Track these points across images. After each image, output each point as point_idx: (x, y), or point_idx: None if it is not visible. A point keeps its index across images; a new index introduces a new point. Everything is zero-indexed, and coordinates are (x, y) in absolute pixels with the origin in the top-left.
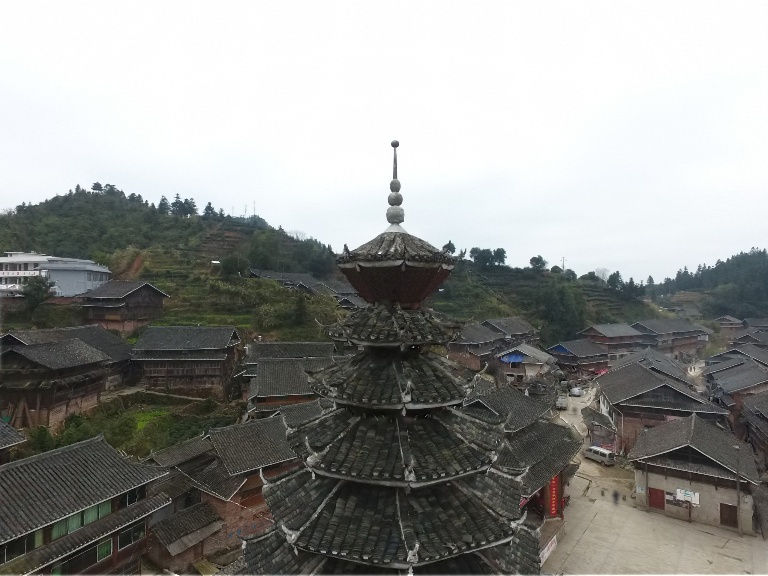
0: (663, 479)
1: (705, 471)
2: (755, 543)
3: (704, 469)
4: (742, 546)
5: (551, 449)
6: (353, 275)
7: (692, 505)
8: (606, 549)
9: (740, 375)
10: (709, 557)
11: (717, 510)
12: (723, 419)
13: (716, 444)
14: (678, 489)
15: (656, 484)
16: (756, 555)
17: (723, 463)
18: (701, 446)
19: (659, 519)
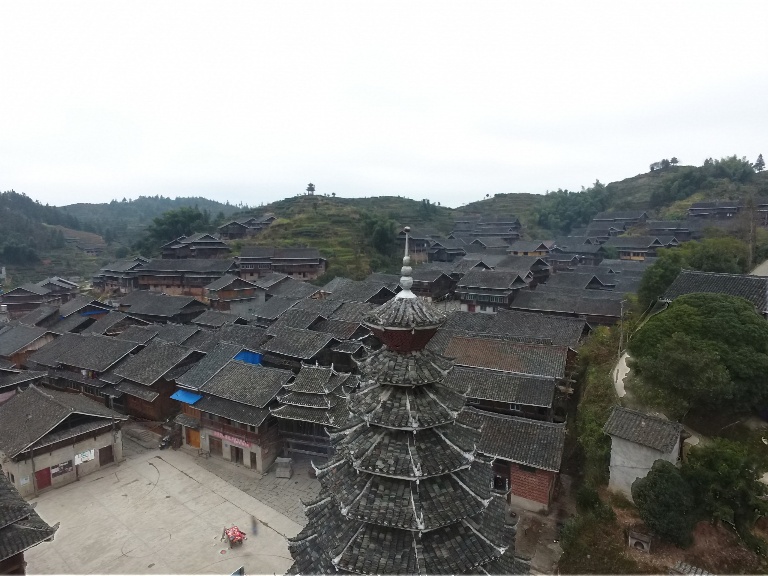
0: (48, 457)
1: (87, 429)
2: (130, 464)
3: (85, 428)
4: (127, 471)
5: (2, 480)
6: (423, 333)
7: (78, 465)
8: (49, 550)
9: (5, 336)
10: (121, 493)
11: (97, 457)
12: (40, 381)
13: (74, 403)
14: (76, 455)
15: (41, 465)
16: (140, 471)
17: (102, 415)
18: (78, 409)
19: (54, 495)
